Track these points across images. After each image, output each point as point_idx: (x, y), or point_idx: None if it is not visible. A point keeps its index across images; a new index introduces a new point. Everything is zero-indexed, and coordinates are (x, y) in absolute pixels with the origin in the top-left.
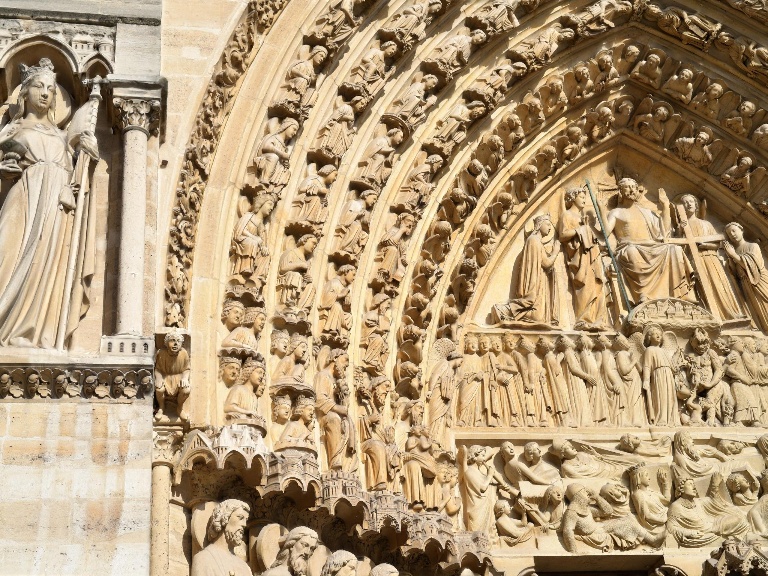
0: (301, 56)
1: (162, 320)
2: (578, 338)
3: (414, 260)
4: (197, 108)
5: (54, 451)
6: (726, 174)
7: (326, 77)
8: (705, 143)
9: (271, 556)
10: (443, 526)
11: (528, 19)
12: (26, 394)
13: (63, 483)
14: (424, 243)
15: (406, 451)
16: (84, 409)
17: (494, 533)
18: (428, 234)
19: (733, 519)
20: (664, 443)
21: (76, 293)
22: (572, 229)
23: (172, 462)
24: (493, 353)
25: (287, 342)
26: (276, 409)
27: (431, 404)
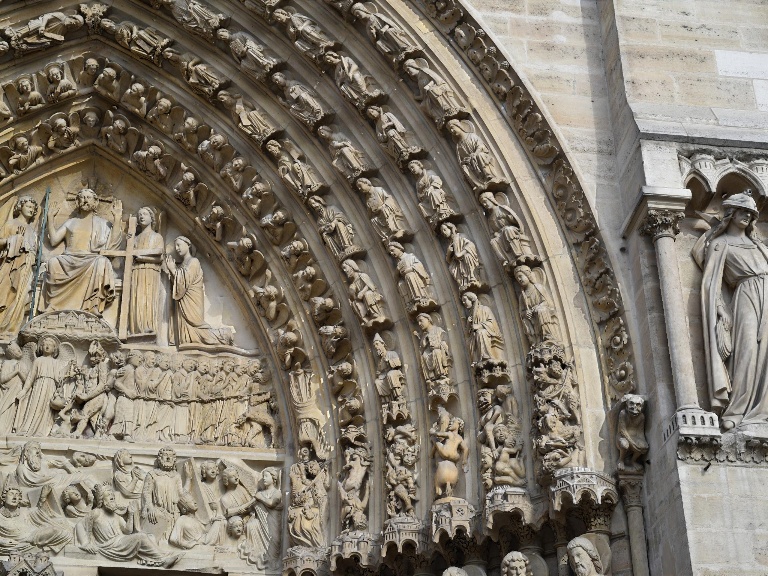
0: None
1: None
2: None
3: None
4: None
5: None
6: (174, 188)
7: None
8: (156, 157)
9: None
10: None
11: None
12: None
13: None
14: None
15: None
16: None
17: None
18: None
19: (48, 530)
20: (14, 452)
21: None
22: (6, 238)
23: None
24: None
25: None
26: None
27: None
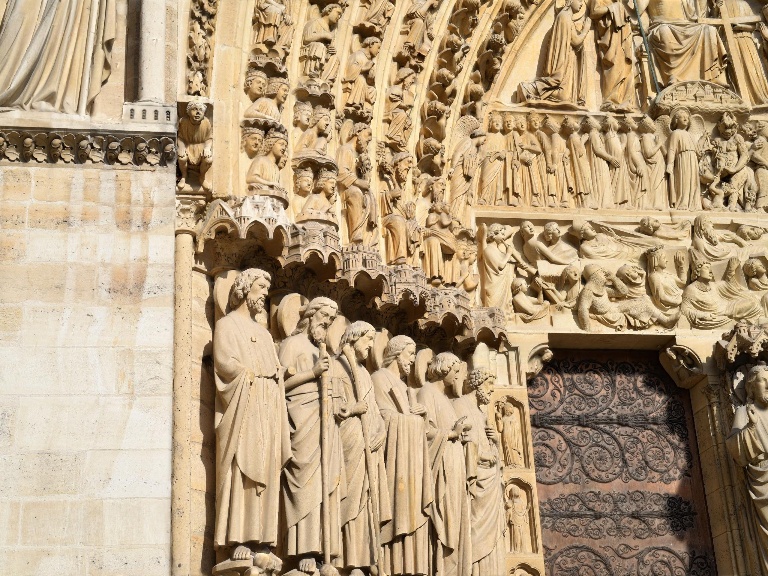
0: None
1: (184, 88)
2: (604, 119)
3: (440, 34)
4: None
5: (79, 216)
6: None
7: None
8: None
9: (292, 324)
10: (460, 301)
11: None
12: (49, 159)
13: (88, 247)
14: (451, 17)
15: (426, 227)
16: (107, 175)
17: (510, 310)
18: (456, 7)
19: (747, 303)
20: (684, 227)
21: (97, 58)
22: (604, 6)
23: (195, 231)
24: (517, 132)
25: (310, 114)
26: (298, 181)
27: (453, 181)
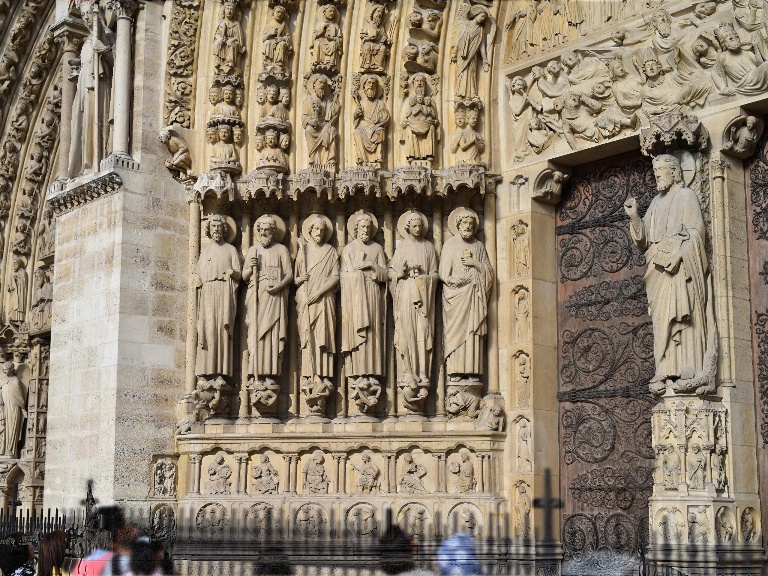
0: None
1: (163, 124)
2: None
3: None
4: None
5: None
6: None
7: None
8: None
9: None
10: (408, 175)
11: None
12: None
13: None
14: None
15: None
16: (106, 200)
17: (525, 147)
18: None
19: (686, 88)
20: None
21: None
22: None
23: None
24: None
25: (262, 95)
26: None
27: None
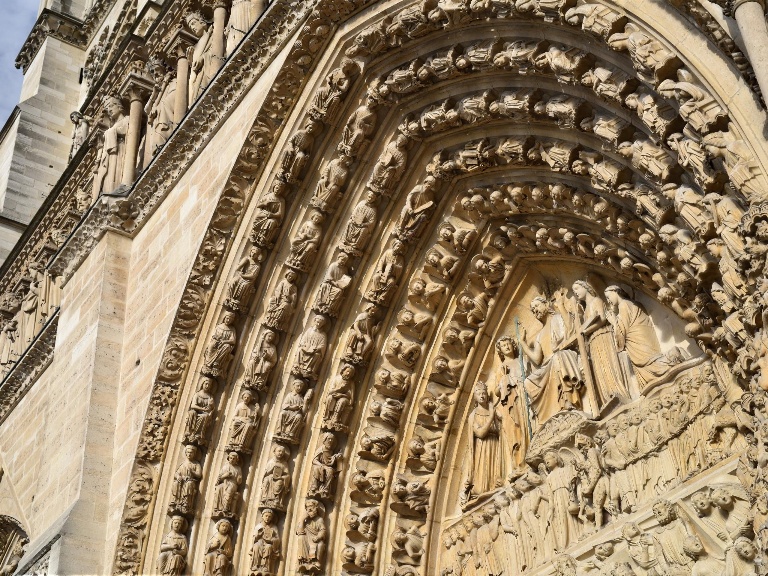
0: (185, 458)
1: None
2: None
3: None
4: (114, 556)
5: None
6: (573, 253)
7: (215, 451)
8: (546, 238)
9: None
10: None
11: (366, 261)
12: None
13: None
14: None
15: None
16: None
17: None
18: None
19: None
20: None
21: None
22: None
23: None
24: (460, 540)
25: None
26: None
27: None
